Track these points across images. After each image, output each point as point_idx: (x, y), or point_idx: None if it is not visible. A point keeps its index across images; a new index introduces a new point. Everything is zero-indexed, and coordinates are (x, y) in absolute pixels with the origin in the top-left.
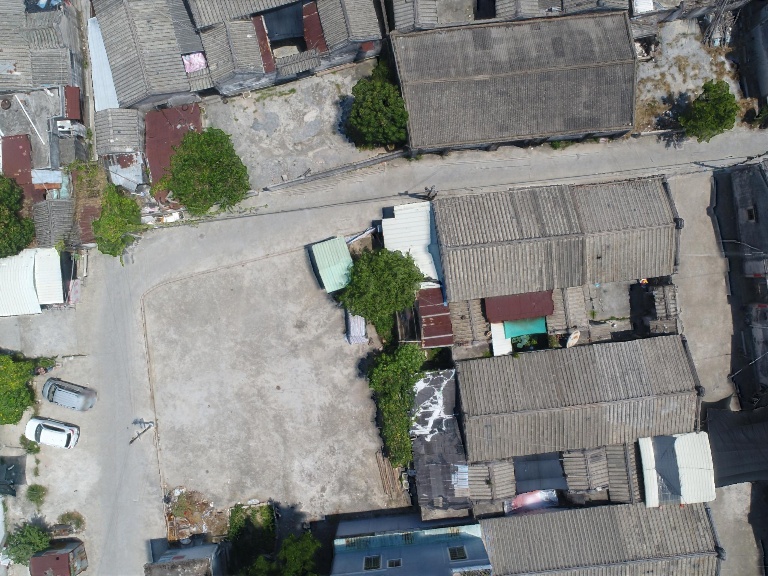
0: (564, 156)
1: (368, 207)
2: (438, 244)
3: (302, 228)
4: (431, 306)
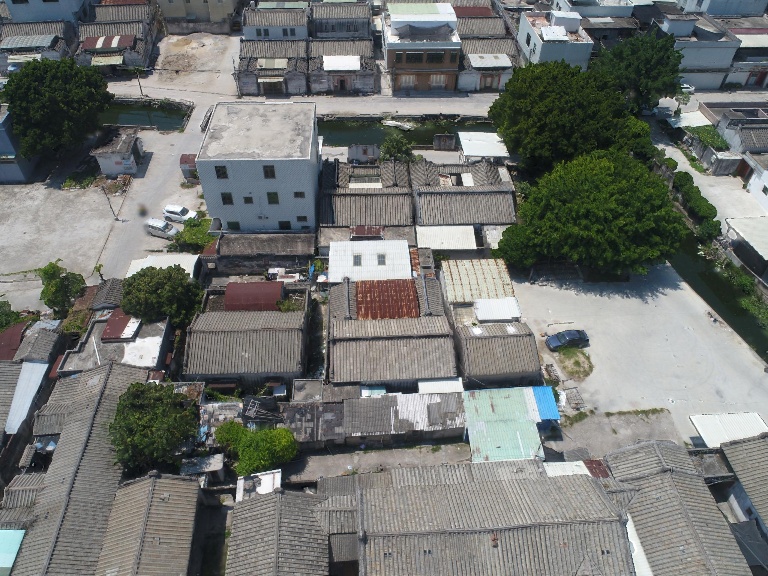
0: None
1: None
2: None
3: None
4: None
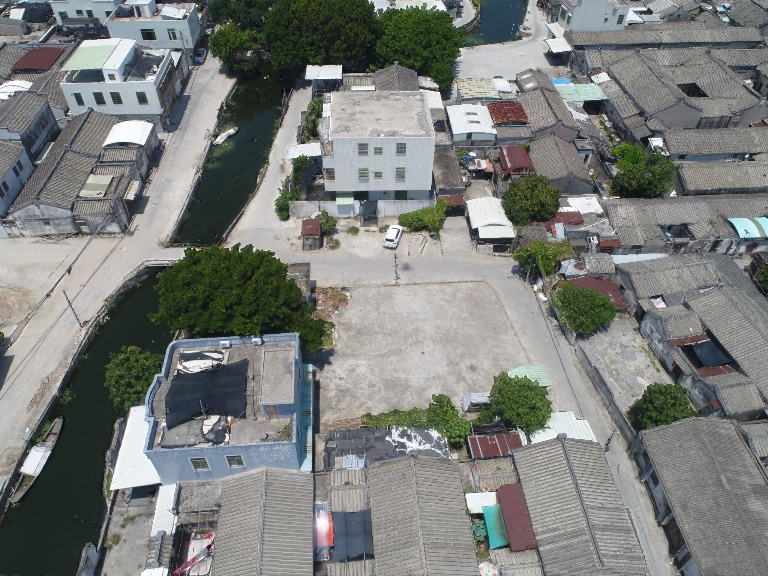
0: None
1: (578, 418)
2: None
3: (551, 372)
4: (506, 442)
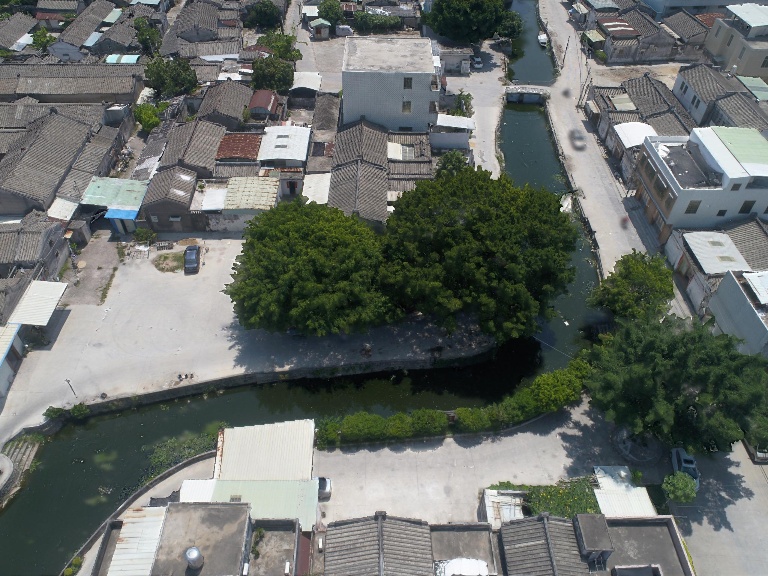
0: (294, 3)
1: (300, 31)
2: (319, 4)
3: None
4: None
